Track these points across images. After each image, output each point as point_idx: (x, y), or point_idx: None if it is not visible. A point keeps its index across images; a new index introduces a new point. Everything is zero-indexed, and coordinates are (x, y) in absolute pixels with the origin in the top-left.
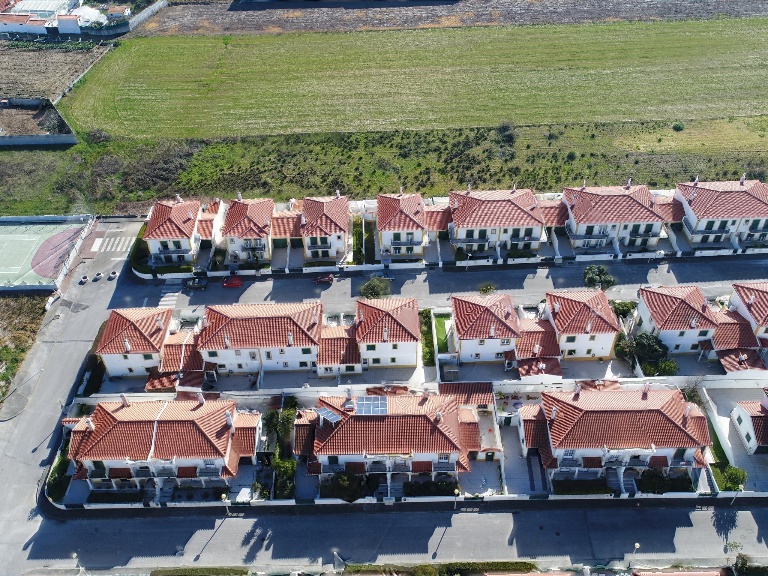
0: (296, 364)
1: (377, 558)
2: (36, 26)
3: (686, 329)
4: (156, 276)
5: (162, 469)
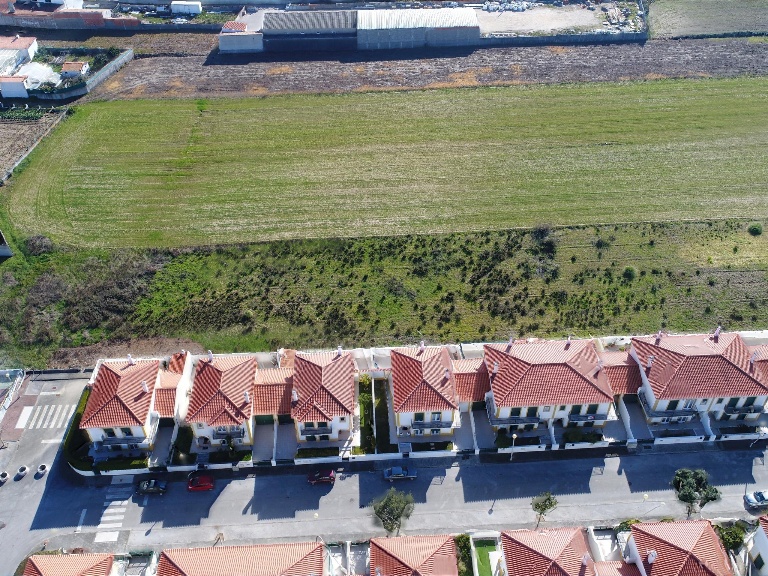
0: None
1: None
2: None
3: None
4: (99, 473)
5: None
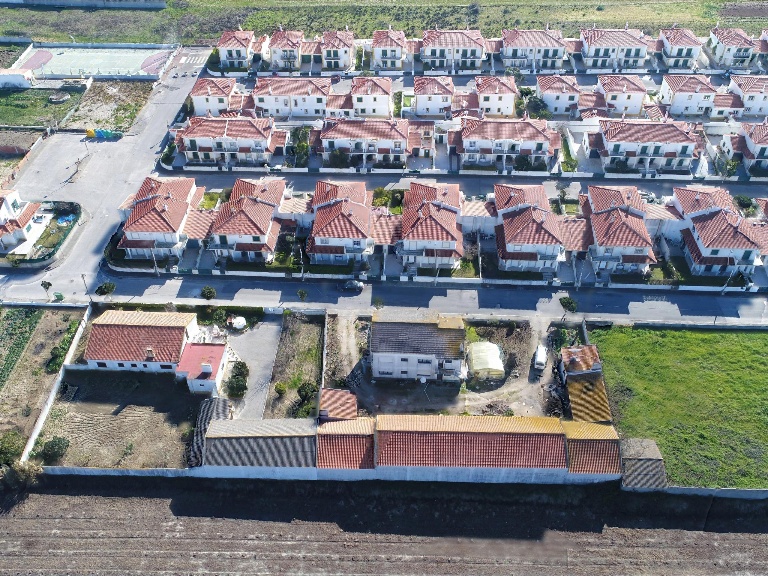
0: (313, 111)
1: None
2: None
3: (560, 93)
4: (224, 74)
5: (230, 148)
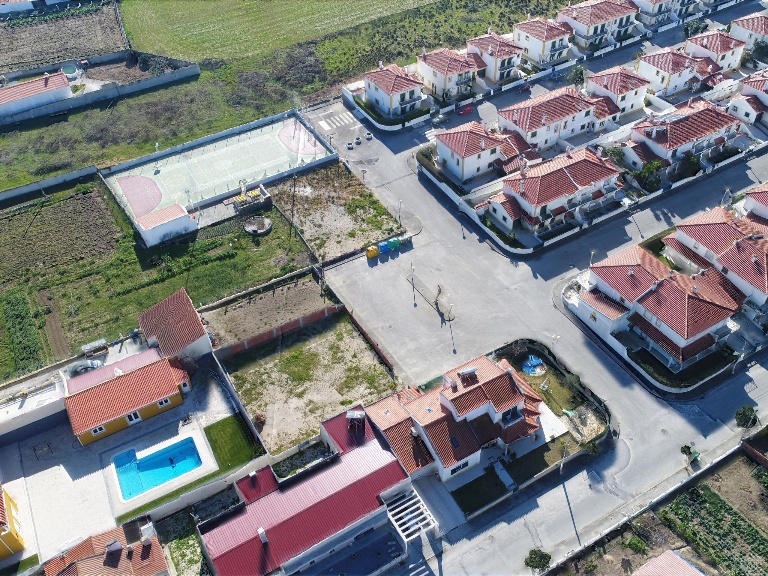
0: (579, 128)
1: None
2: (21, 2)
3: None
4: (404, 125)
5: None
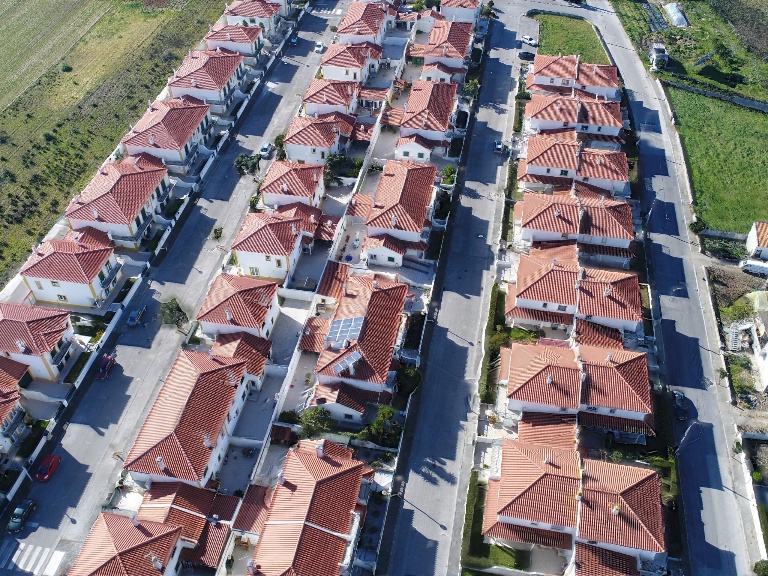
0: (241, 403)
1: (470, 379)
2: None
3: None
4: None
5: None
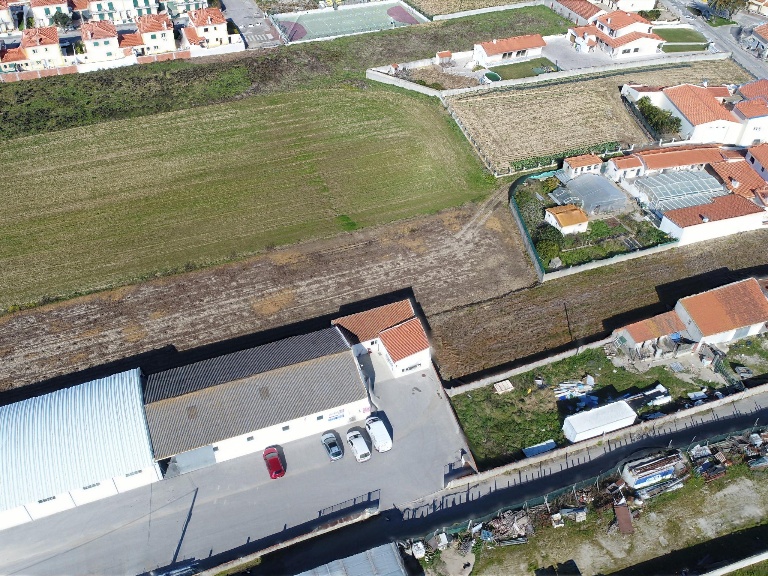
0: None
1: None
2: None
3: None
4: None
5: None
